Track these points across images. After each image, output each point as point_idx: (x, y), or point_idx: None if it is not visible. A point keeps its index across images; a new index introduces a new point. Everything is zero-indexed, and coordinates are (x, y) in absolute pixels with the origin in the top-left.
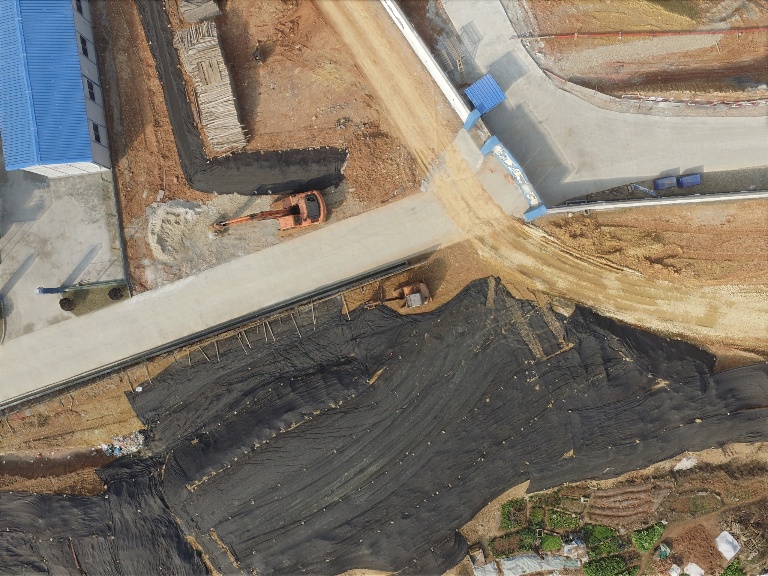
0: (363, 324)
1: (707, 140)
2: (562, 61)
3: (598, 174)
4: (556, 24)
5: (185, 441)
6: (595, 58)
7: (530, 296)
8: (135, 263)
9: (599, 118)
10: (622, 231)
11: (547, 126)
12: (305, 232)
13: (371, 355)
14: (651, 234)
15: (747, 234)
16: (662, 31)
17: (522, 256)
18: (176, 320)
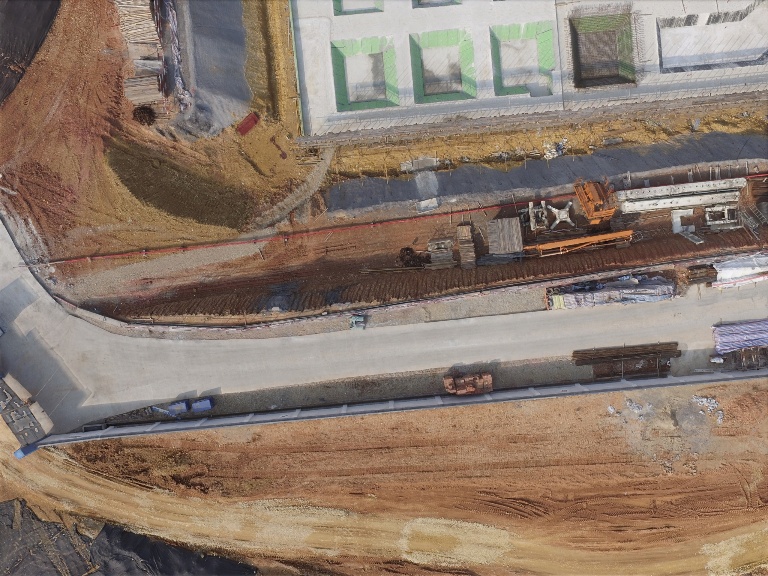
0: None
1: (223, 362)
2: (75, 285)
3: (115, 398)
4: (70, 247)
5: None
6: (116, 278)
7: (56, 518)
8: None
9: (111, 343)
10: (146, 452)
11: (59, 352)
12: None
13: None
14: (176, 454)
15: (274, 452)
16: (196, 243)
17: (47, 478)
18: None
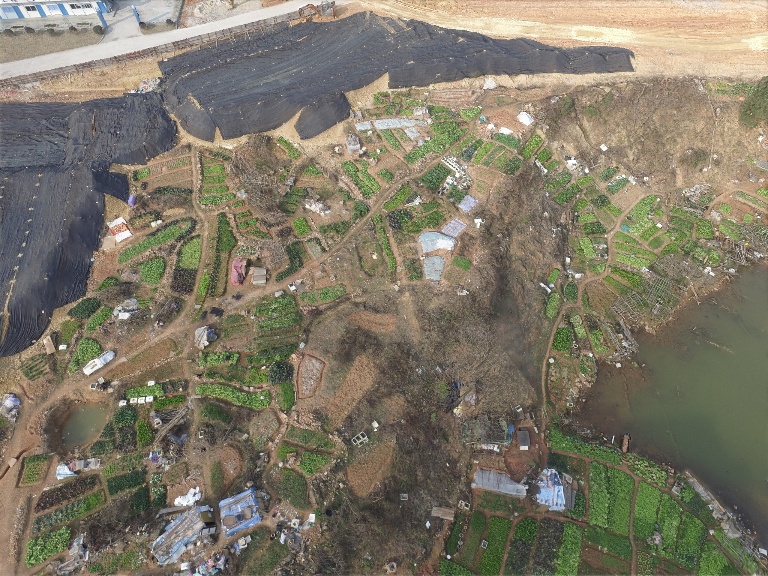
0: None
1: None
2: None
3: None
4: None
5: None
6: None
7: (388, 16)
8: (184, 18)
9: None
10: None
11: None
12: (275, 5)
13: None
14: None
15: (499, 1)
16: None
17: (384, 6)
18: None
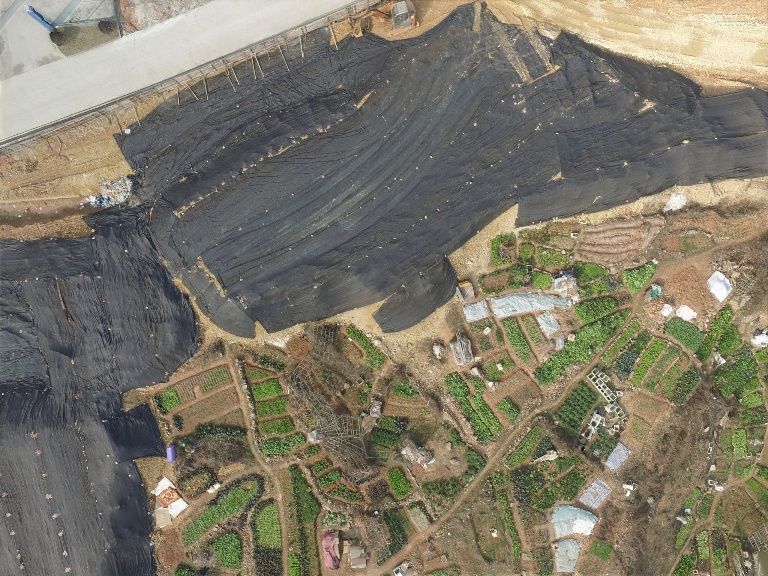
0: (351, 53)
1: None
2: None
3: None
4: None
5: (173, 182)
6: None
7: (516, 20)
8: (125, 2)
9: None
10: None
11: None
12: None
13: (359, 83)
14: None
15: None
16: None
17: None
18: (165, 60)
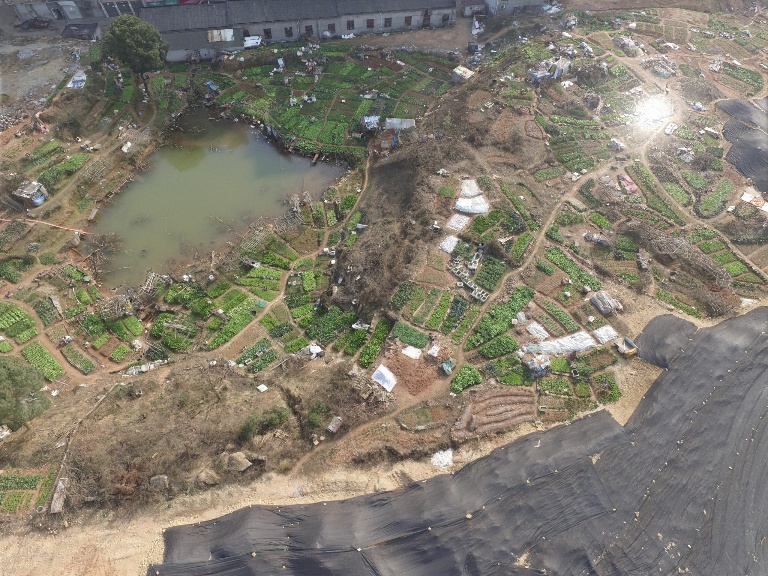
0: None
1: None
2: None
3: None
4: None
5: None
6: None
7: None
8: None
9: None
10: None
11: None
12: None
13: None
14: None
15: None
16: None
17: None
18: None
